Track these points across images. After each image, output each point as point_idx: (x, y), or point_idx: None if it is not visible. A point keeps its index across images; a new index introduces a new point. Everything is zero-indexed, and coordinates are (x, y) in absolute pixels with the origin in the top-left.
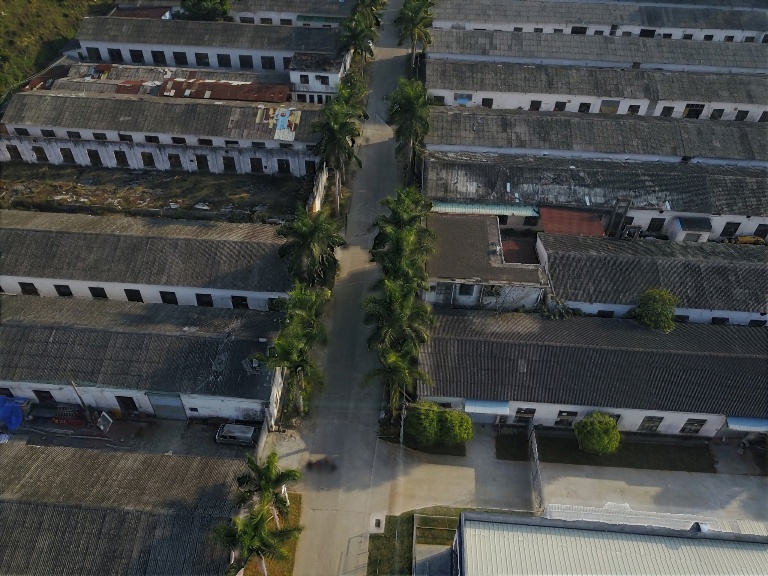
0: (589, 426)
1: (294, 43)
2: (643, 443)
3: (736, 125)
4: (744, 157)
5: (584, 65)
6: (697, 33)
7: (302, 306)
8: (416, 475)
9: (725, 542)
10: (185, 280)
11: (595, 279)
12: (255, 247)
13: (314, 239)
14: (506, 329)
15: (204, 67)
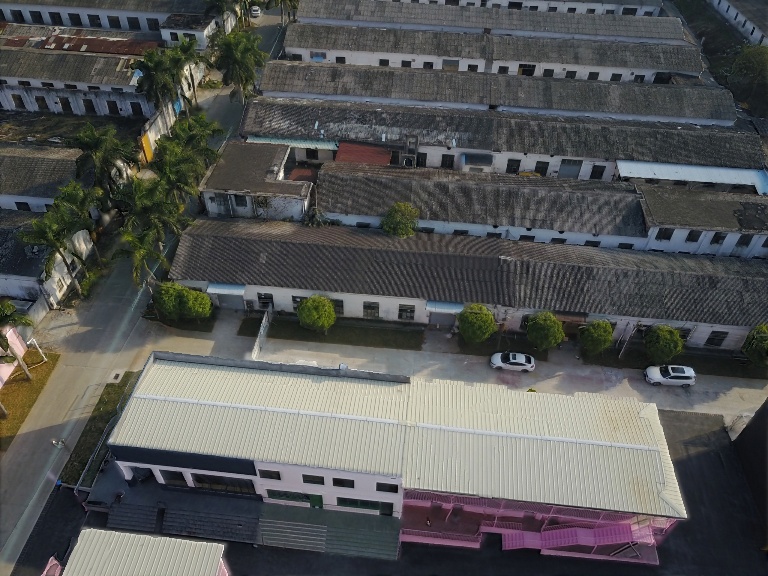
0: (303, 304)
1: (175, 6)
2: (368, 328)
3: (545, 79)
4: (543, 106)
5: (439, 30)
6: (561, 6)
7: (71, 200)
8: (163, 344)
9: (363, 380)
10: (4, 189)
11: (355, 195)
12: (69, 164)
13: (98, 150)
14: (262, 231)
15: (96, 28)
